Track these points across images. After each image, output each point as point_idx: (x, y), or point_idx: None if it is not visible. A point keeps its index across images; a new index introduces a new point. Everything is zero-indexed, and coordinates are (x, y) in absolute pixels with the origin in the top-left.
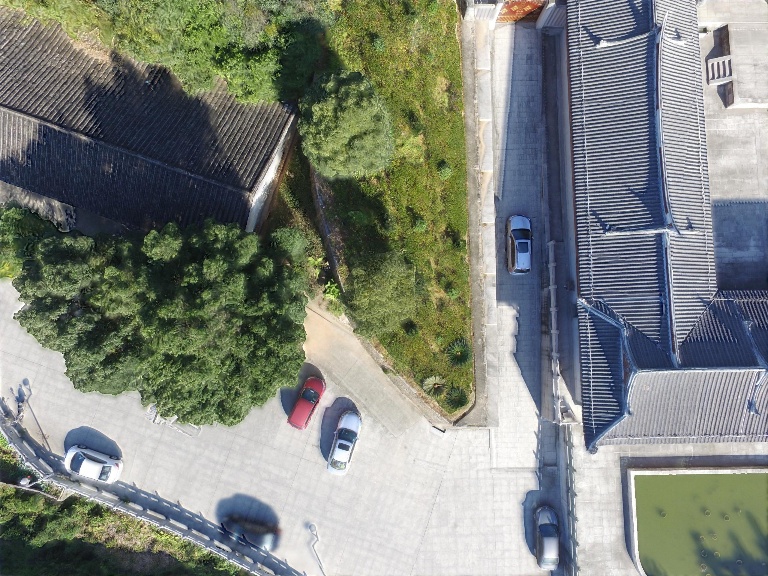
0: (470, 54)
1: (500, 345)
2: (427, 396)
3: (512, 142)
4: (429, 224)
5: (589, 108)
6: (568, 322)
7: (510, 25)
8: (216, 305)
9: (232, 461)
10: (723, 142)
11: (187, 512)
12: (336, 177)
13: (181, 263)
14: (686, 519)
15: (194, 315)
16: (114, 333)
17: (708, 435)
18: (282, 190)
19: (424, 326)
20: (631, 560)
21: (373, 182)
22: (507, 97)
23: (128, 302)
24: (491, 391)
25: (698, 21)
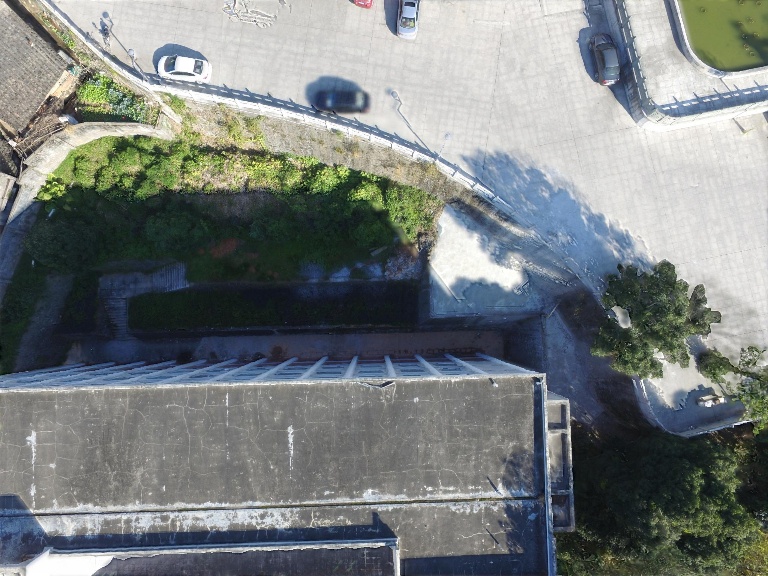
0: None
1: None
2: None
3: None
4: None
5: None
6: None
7: None
8: None
9: (310, 50)
10: None
11: (278, 101)
12: None
13: None
14: (724, 12)
15: None
16: None
17: None
18: None
19: None
20: (682, 55)
21: None
22: None
23: None
24: None
25: None
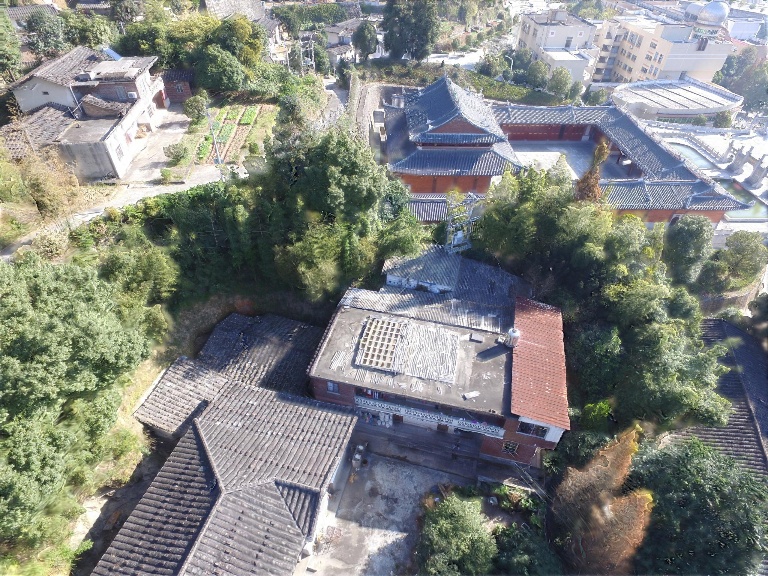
0: None
1: None
2: None
3: None
4: None
5: None
6: None
7: None
8: None
9: None
10: None
11: None
12: None
13: None
14: None
15: None
16: None
17: None
18: None
19: None
20: None
21: None
22: None
23: None
24: None
25: None
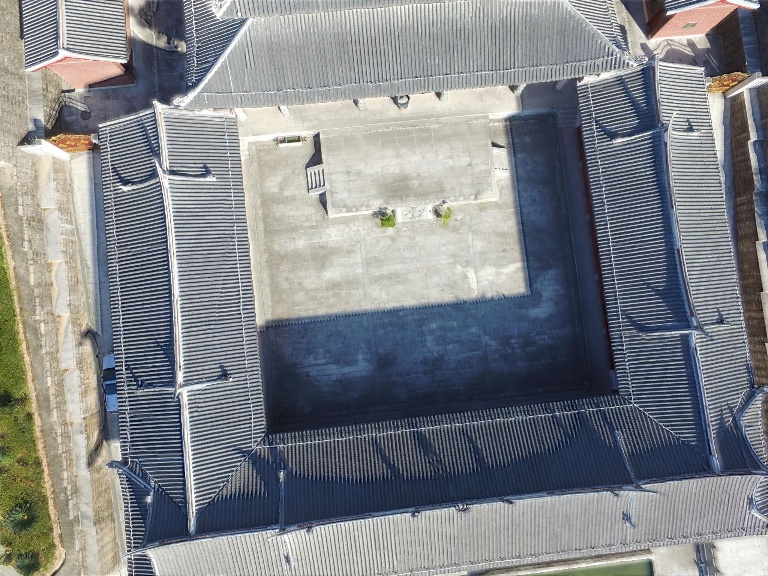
0: (13, 201)
1: None
2: None
3: (104, 275)
4: None
5: (121, 255)
6: None
7: (87, 154)
8: None
9: None
10: (327, 253)
11: None
12: None
13: None
14: None
15: None
16: None
17: None
18: None
19: None
20: None
21: None
22: (93, 229)
23: None
24: (89, 542)
25: (286, 132)
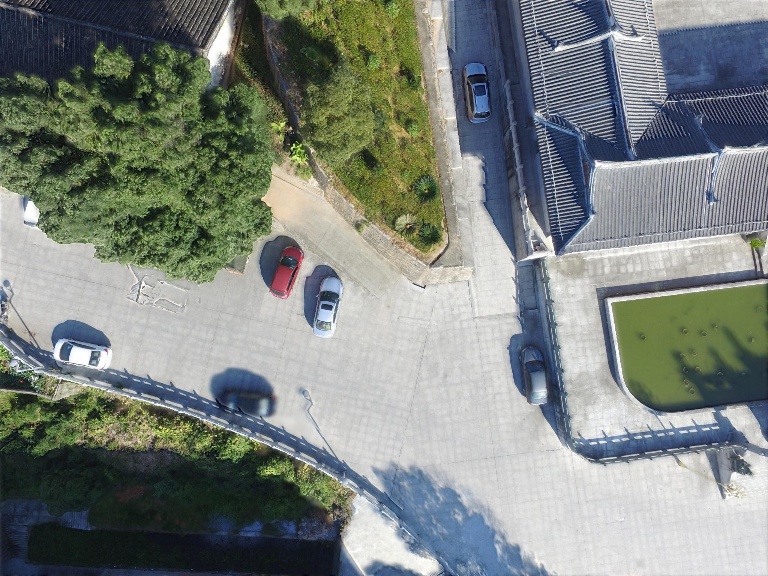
0: None
1: (470, 196)
2: (401, 241)
3: None
4: (383, 63)
5: None
6: (532, 160)
7: None
8: (172, 110)
9: (220, 338)
10: None
11: (181, 392)
12: (287, 29)
13: (135, 86)
14: (665, 340)
15: (151, 118)
16: (78, 165)
17: (672, 231)
18: (238, 61)
19: (389, 164)
20: (616, 384)
21: (324, 28)
22: None
23: (86, 120)
24: (464, 233)
25: None
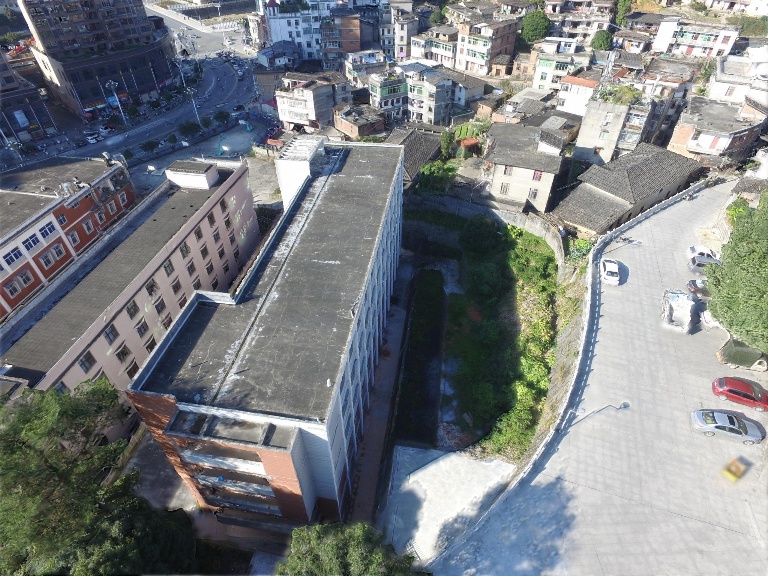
0: None
1: None
2: None
3: None
4: None
5: None
6: None
7: None
8: None
9: (652, 346)
10: None
11: (597, 321)
12: None
13: None
14: None
15: None
16: None
17: None
18: None
19: None
20: None
21: None
22: None
23: None
24: None
25: None
